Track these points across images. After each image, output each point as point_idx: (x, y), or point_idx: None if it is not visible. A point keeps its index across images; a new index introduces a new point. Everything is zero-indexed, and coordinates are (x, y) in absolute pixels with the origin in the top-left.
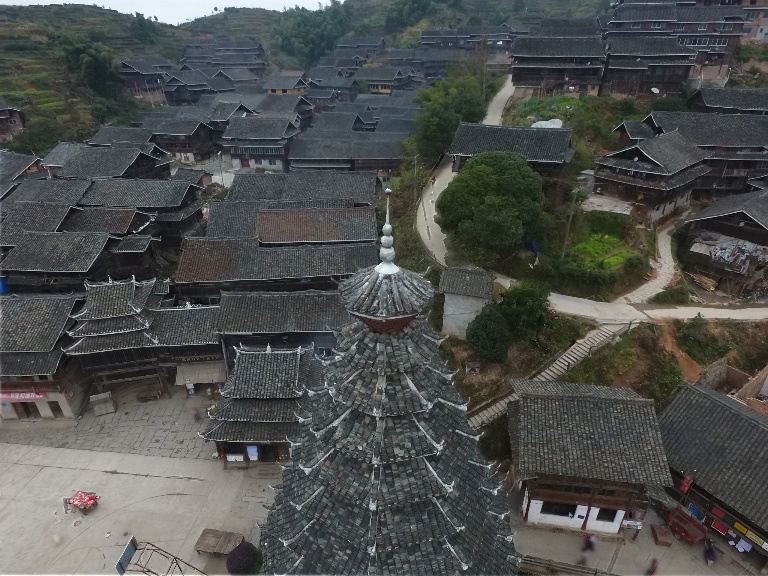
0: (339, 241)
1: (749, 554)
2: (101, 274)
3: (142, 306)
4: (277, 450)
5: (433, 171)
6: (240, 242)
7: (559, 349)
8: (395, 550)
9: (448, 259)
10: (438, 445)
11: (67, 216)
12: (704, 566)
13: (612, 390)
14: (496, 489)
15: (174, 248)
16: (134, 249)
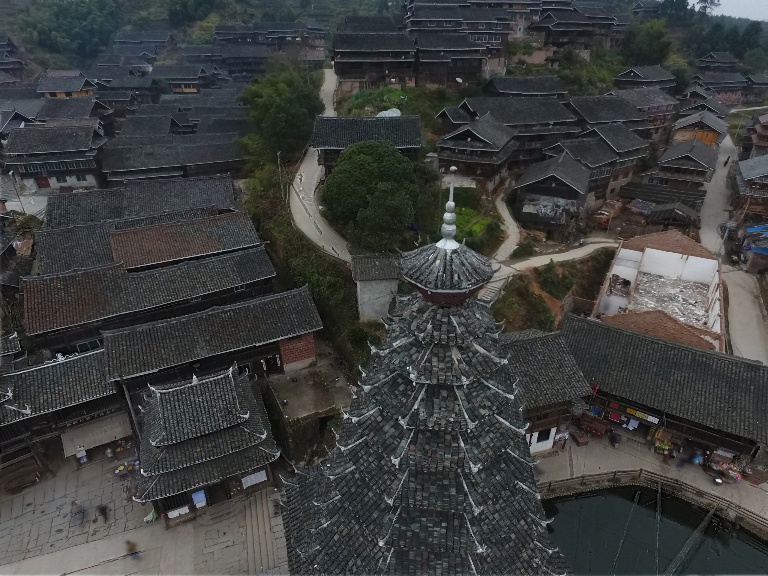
0: (219, 252)
1: (637, 429)
2: None
3: None
4: (228, 486)
5: (298, 167)
6: (101, 272)
7: None
8: None
9: (353, 249)
10: (512, 396)
11: None
12: (613, 450)
13: (522, 333)
14: None
15: None
16: None
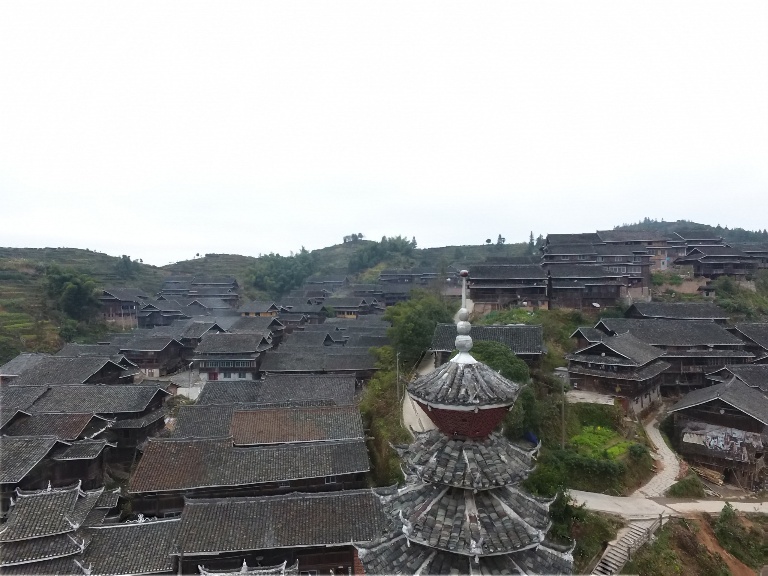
0: (322, 441)
1: None
2: (33, 488)
3: (82, 521)
4: None
5: (415, 368)
6: (212, 443)
7: (592, 555)
8: None
9: None
10: None
11: (10, 422)
12: None
13: None
14: None
15: (124, 462)
16: (83, 455)
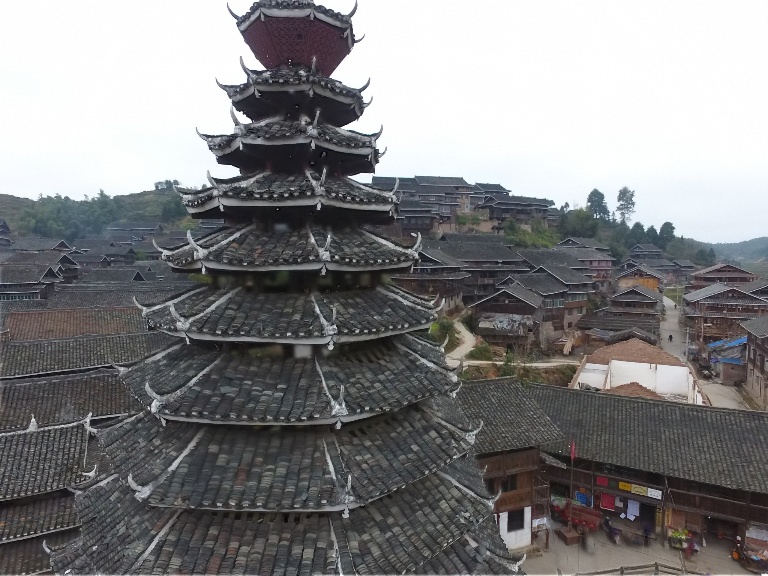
0: None
1: (640, 518)
2: None
3: None
4: None
5: None
6: None
7: None
8: (355, 370)
9: None
10: (391, 193)
11: None
12: (614, 547)
13: None
14: (442, 346)
15: None
16: None
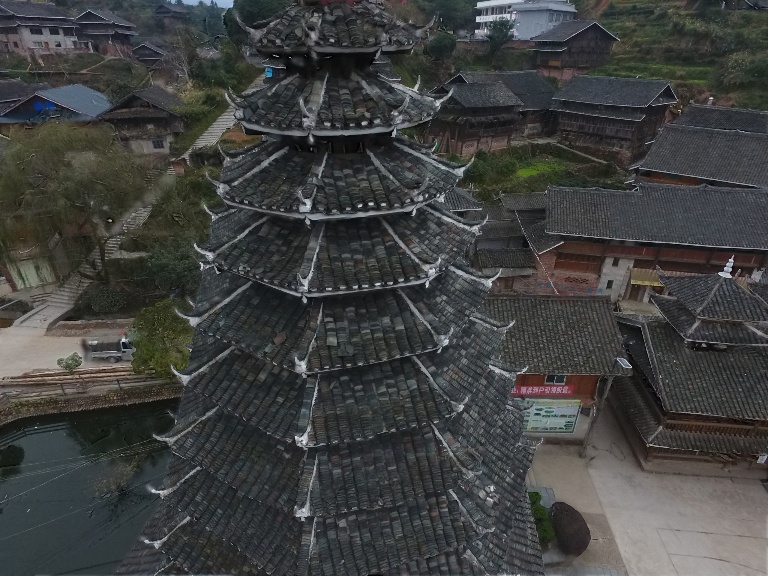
0: None
1: None
2: None
3: None
4: None
5: None
6: None
7: None
8: None
9: None
10: None
11: None
12: None
13: None
14: None
15: None
16: None
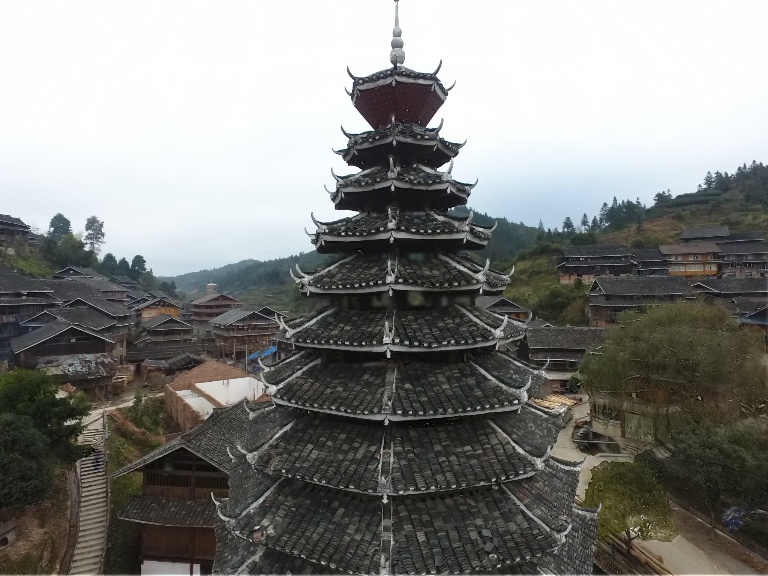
0: None
1: None
2: None
3: None
4: None
5: None
6: None
7: (64, 470)
8: None
9: None
10: None
11: None
12: None
13: None
14: None
15: None
16: None
